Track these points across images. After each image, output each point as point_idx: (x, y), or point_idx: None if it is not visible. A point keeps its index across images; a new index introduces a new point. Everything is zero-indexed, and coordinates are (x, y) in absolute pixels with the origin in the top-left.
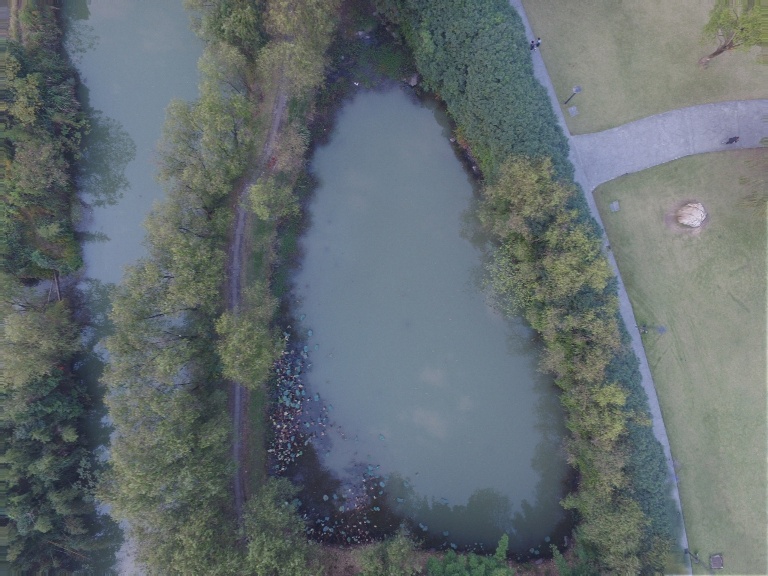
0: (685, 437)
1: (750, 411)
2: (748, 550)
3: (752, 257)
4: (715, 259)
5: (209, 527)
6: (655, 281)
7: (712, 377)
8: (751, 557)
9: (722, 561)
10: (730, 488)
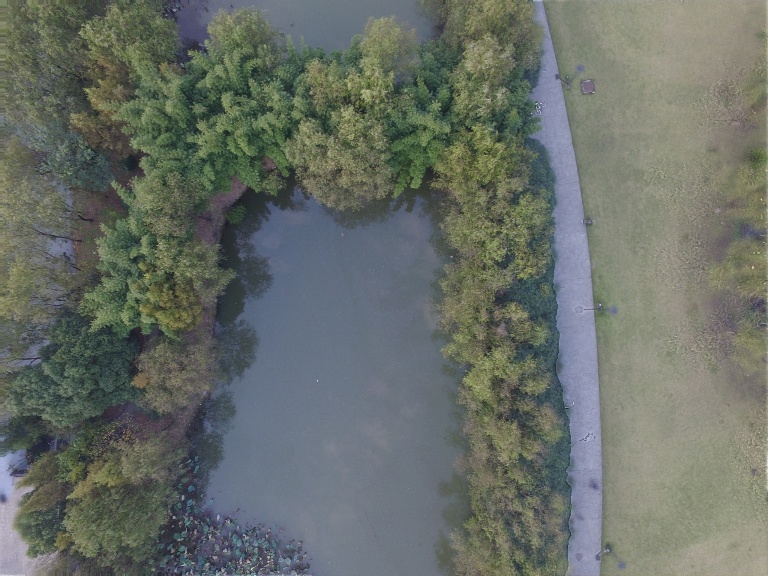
0: None
1: None
2: (620, 76)
3: None
4: None
5: None
6: None
7: None
8: (623, 83)
9: (594, 86)
10: (598, 13)
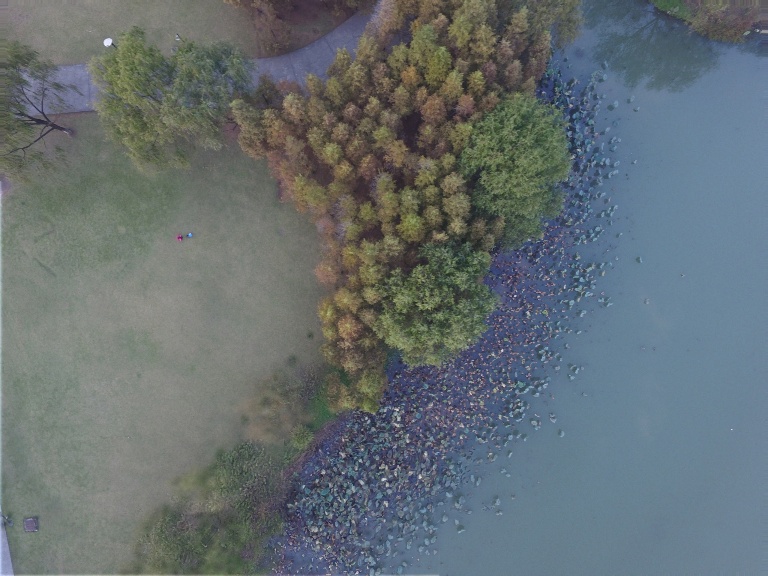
0: None
1: (60, 375)
2: (64, 513)
3: (57, 223)
4: (19, 225)
5: None
6: None
7: (20, 342)
8: (67, 520)
9: (36, 524)
10: (41, 452)
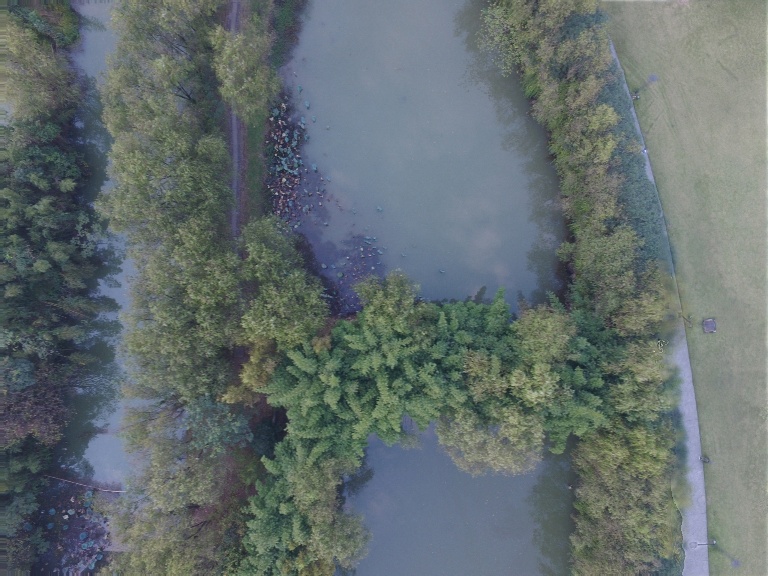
0: (677, 202)
1: (740, 177)
2: (740, 315)
3: (740, 27)
4: (704, 28)
5: (209, 229)
6: (646, 48)
7: (703, 143)
8: (743, 322)
9: (715, 325)
10: (722, 253)
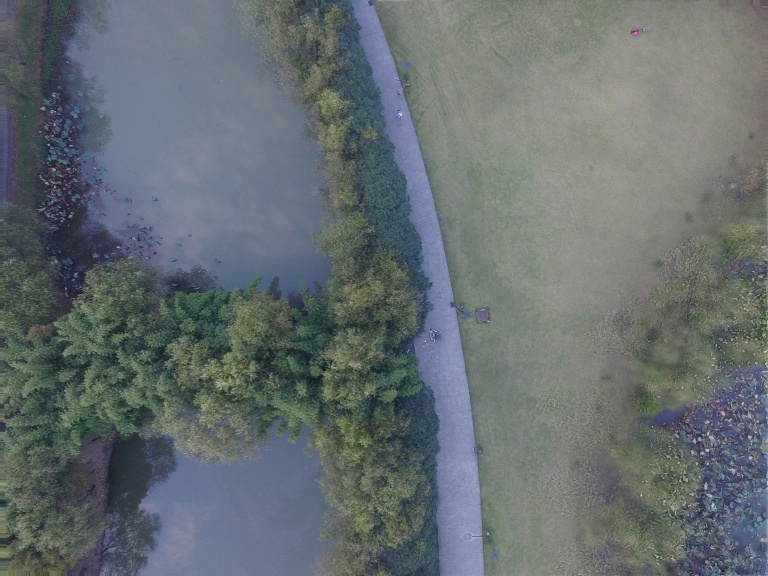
0: (450, 191)
1: (514, 166)
2: (515, 305)
3: (514, 13)
4: (477, 14)
5: None
6: (417, 35)
7: (475, 131)
8: (518, 312)
9: (488, 315)
10: (495, 242)
